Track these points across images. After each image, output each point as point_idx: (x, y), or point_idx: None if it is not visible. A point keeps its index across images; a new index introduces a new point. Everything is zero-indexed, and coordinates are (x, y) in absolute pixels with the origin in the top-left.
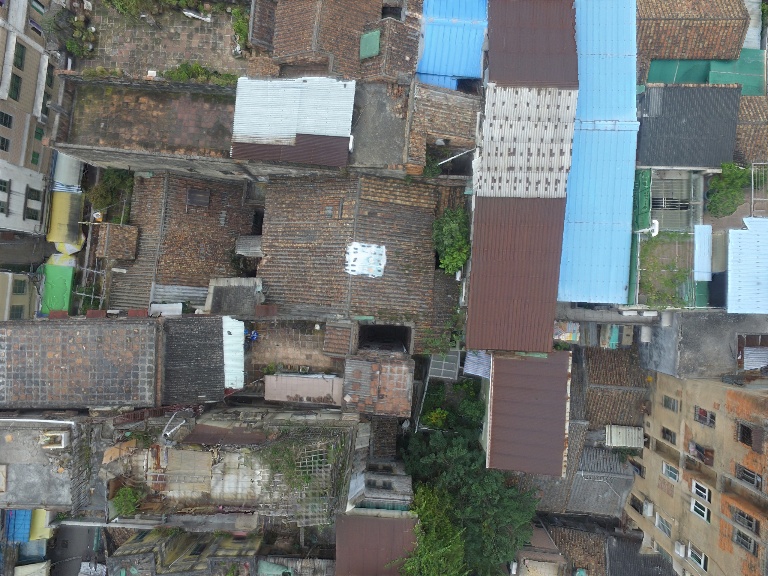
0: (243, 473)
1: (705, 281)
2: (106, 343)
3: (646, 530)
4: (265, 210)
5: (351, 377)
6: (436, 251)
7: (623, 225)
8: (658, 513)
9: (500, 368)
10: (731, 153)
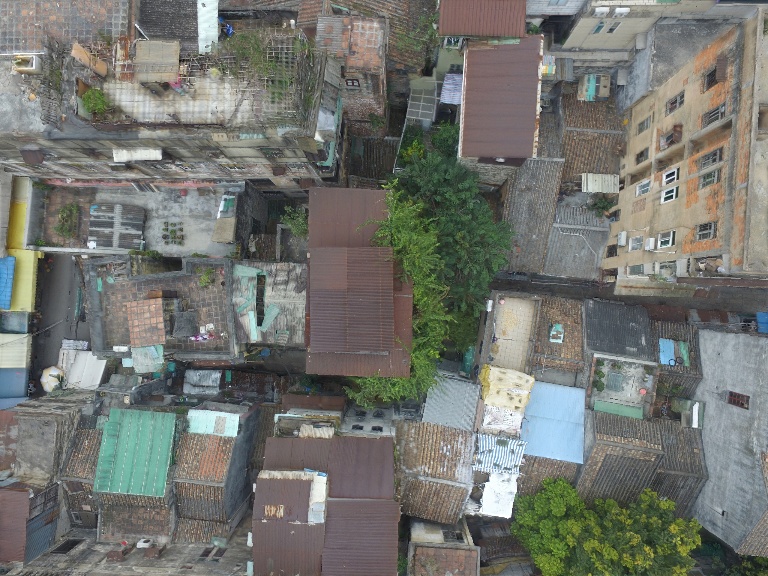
0: (213, 99)
1: None
2: (80, 1)
3: (620, 264)
4: None
5: (323, 33)
6: None
7: None
8: (631, 238)
9: (473, 60)
10: None
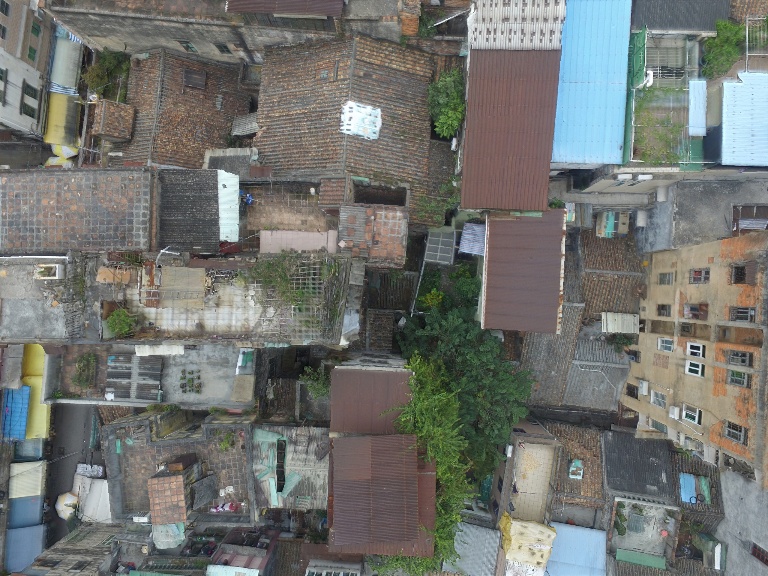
0: (237, 305)
1: (700, 143)
2: (101, 190)
3: (641, 411)
4: (261, 83)
5: (346, 223)
6: (431, 120)
7: (618, 84)
8: (653, 390)
9: (495, 230)
10: (726, 16)
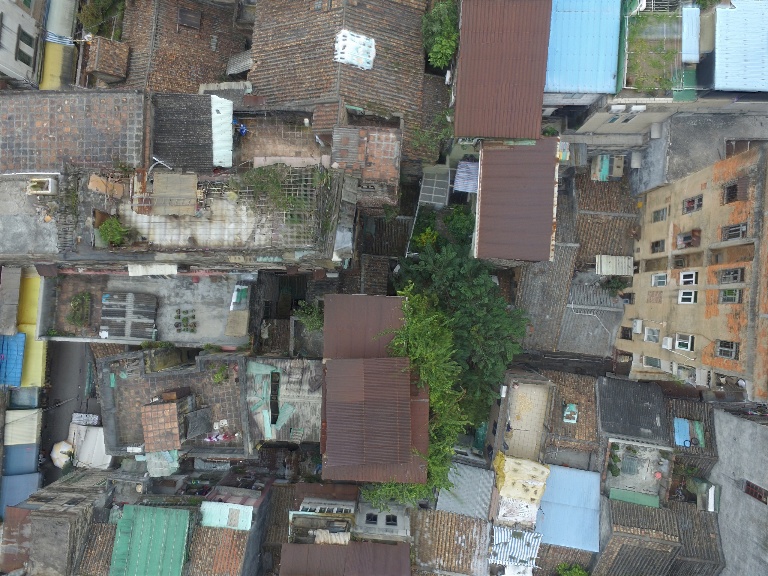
0: (230, 220)
1: (693, 73)
2: (94, 112)
3: (635, 351)
4: (255, 18)
5: (339, 145)
6: (426, 53)
7: (611, 13)
8: (647, 327)
9: (489, 159)
10: None
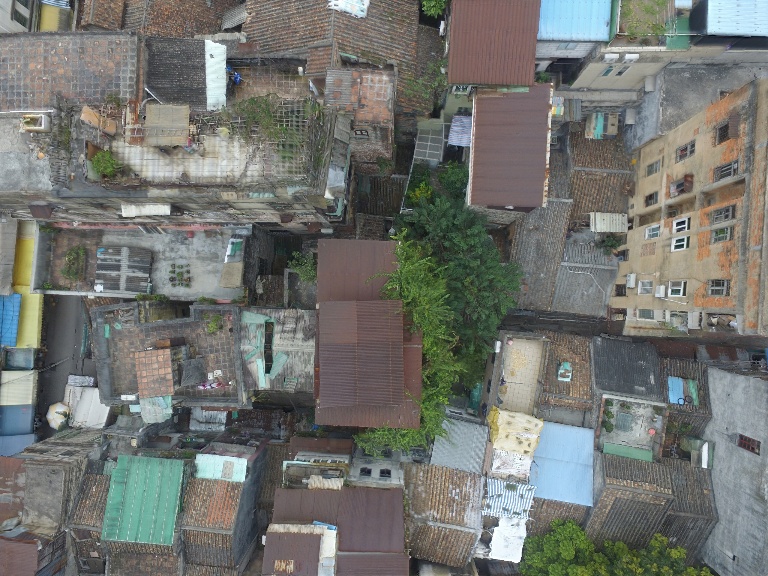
0: (222, 157)
1: (686, 21)
2: (88, 54)
3: (629, 306)
4: None
5: (332, 87)
6: (420, 4)
7: None
8: (640, 281)
9: (482, 107)
10: None
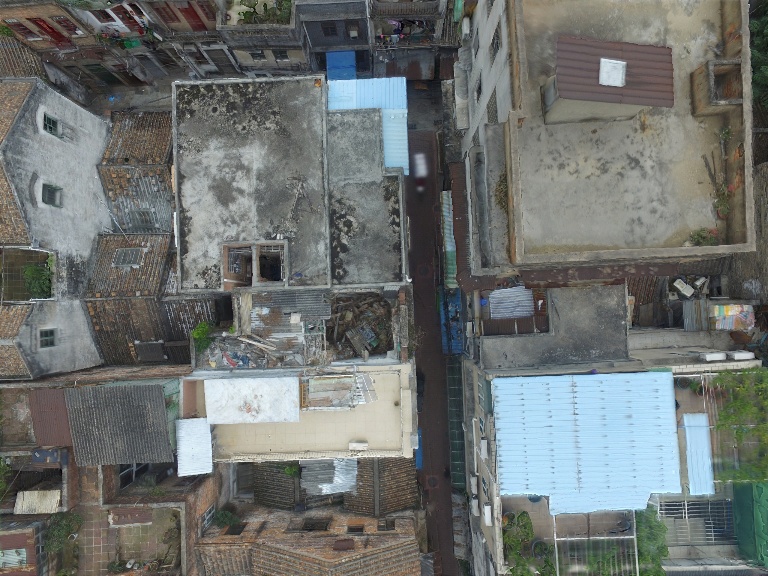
0: None
1: None
2: None
3: None
4: None
5: None
6: None
7: None
8: None
9: None
10: None
